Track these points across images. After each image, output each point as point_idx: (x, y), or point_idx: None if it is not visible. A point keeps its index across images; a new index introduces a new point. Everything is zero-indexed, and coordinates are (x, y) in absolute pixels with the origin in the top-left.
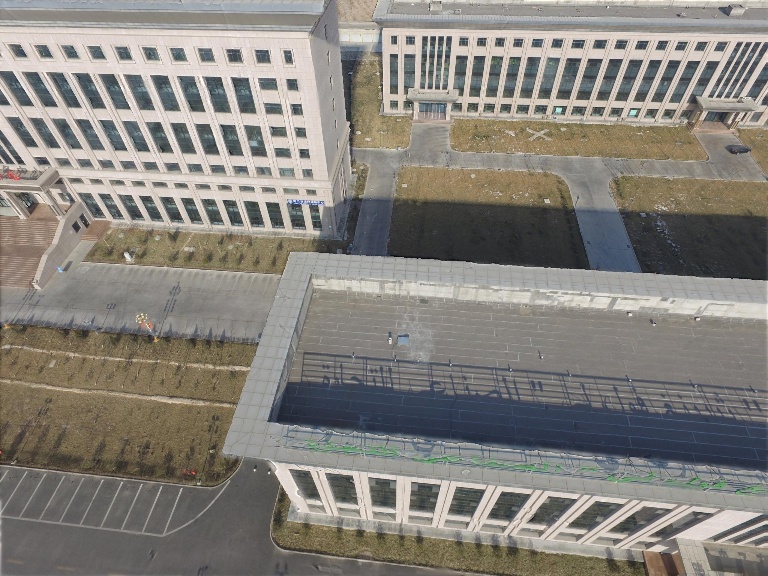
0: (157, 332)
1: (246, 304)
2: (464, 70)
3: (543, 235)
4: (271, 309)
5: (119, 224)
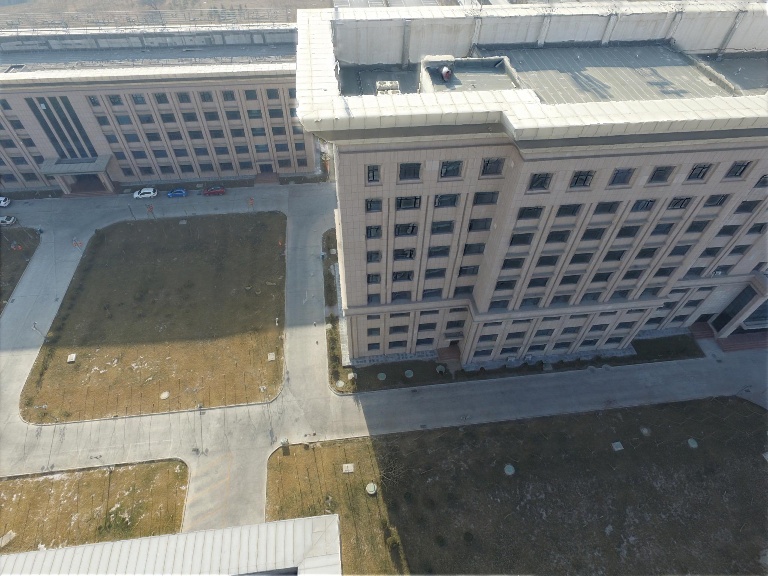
0: None
1: None
2: None
3: None
4: None
5: None
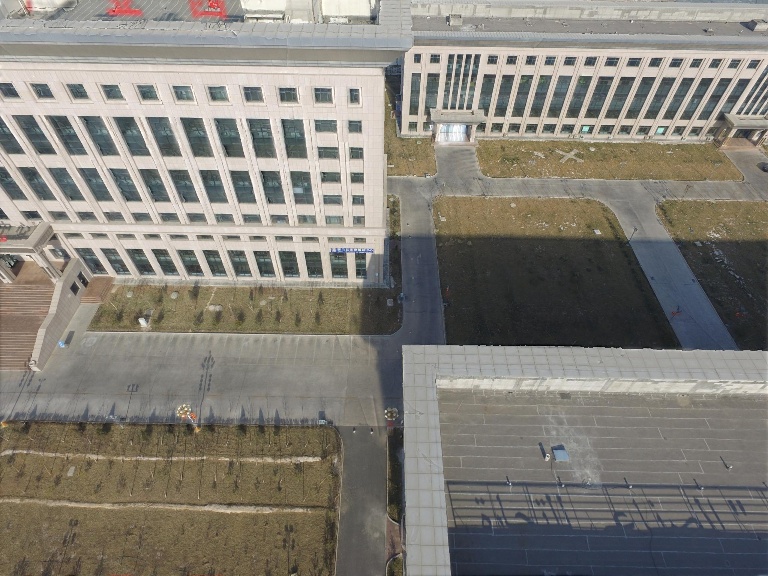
0: (196, 419)
1: (296, 375)
2: (491, 89)
3: (603, 271)
4: (404, 432)
5: (124, 280)
